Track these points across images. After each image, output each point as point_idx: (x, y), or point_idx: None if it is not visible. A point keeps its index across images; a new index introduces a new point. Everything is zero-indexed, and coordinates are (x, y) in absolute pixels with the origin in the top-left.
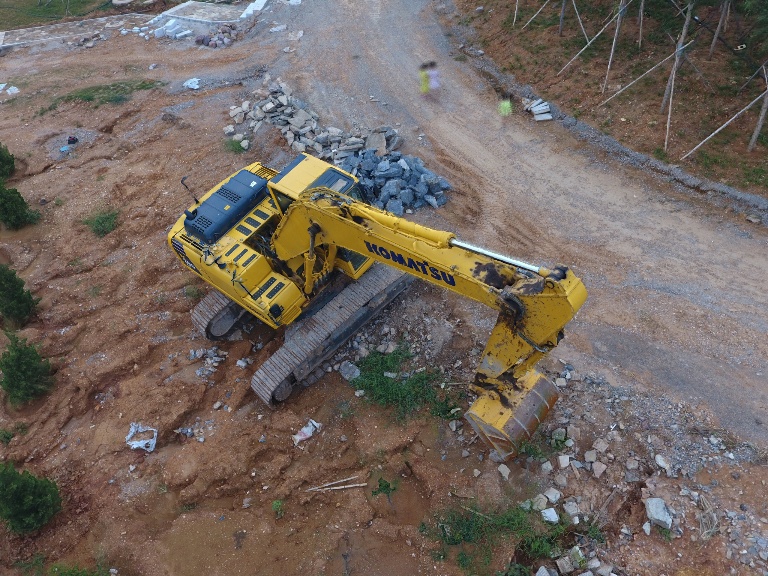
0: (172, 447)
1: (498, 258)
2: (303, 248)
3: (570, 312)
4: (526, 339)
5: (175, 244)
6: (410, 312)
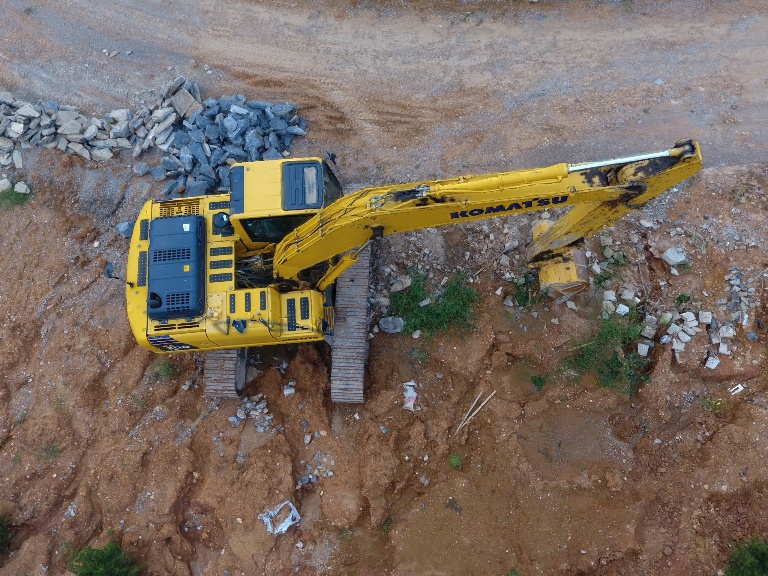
0: (308, 501)
1: (625, 162)
2: (331, 255)
3: (697, 170)
4: (633, 207)
5: (156, 341)
6: (394, 242)
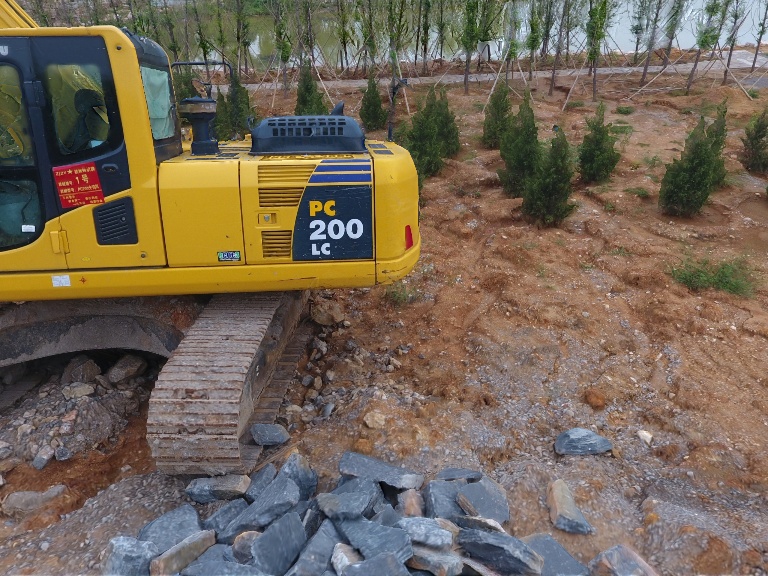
0: None
1: None
2: None
3: None
4: None
5: None
6: None
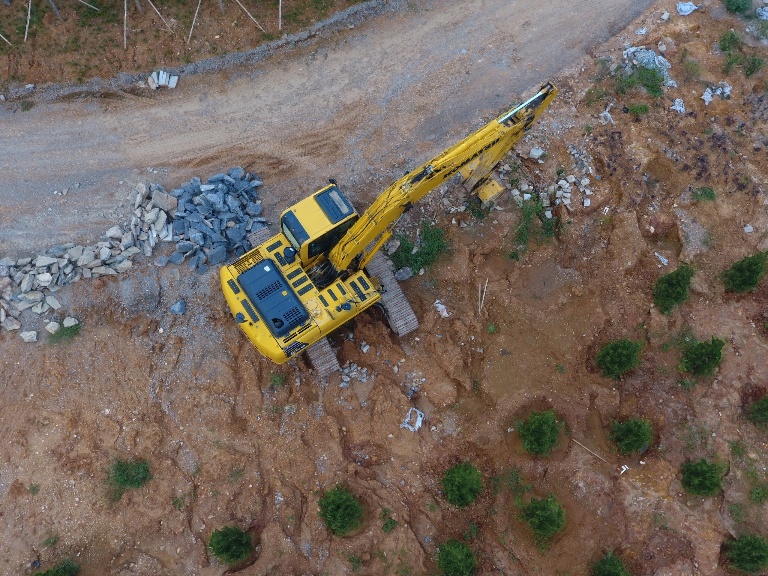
0: (420, 404)
1: None
2: None
3: None
4: None
5: None
6: None
